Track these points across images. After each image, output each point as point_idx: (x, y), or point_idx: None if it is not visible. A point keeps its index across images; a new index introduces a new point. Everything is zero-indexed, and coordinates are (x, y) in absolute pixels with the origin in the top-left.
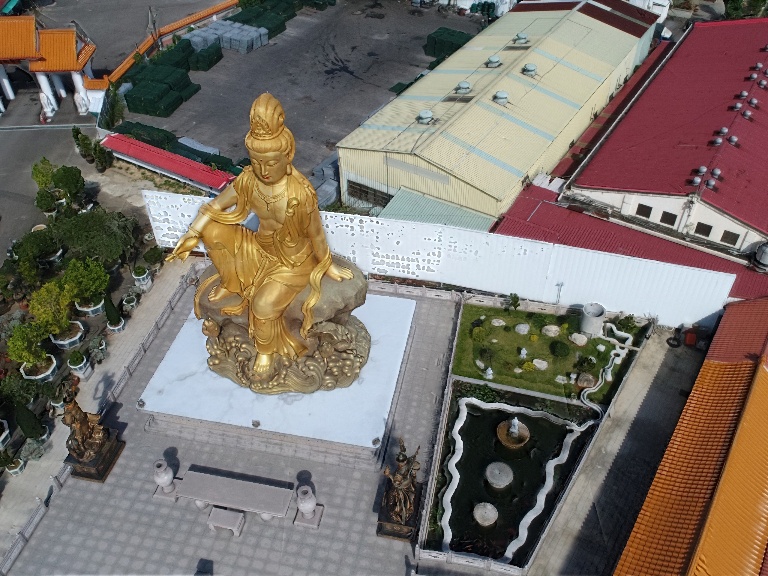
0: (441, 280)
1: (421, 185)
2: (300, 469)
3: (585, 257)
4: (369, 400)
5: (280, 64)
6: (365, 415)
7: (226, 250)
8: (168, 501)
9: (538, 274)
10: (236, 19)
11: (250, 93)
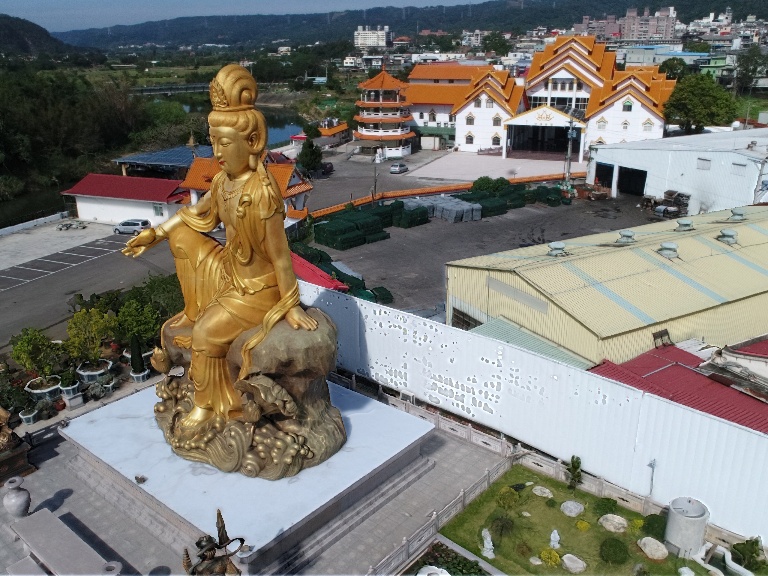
0: (500, 427)
1: (519, 314)
2: (164, 563)
3: (689, 421)
4: (283, 502)
5: (479, 234)
6: (263, 516)
7: (189, 261)
8: (10, 537)
9: (622, 440)
10: (458, 196)
11: (432, 247)
